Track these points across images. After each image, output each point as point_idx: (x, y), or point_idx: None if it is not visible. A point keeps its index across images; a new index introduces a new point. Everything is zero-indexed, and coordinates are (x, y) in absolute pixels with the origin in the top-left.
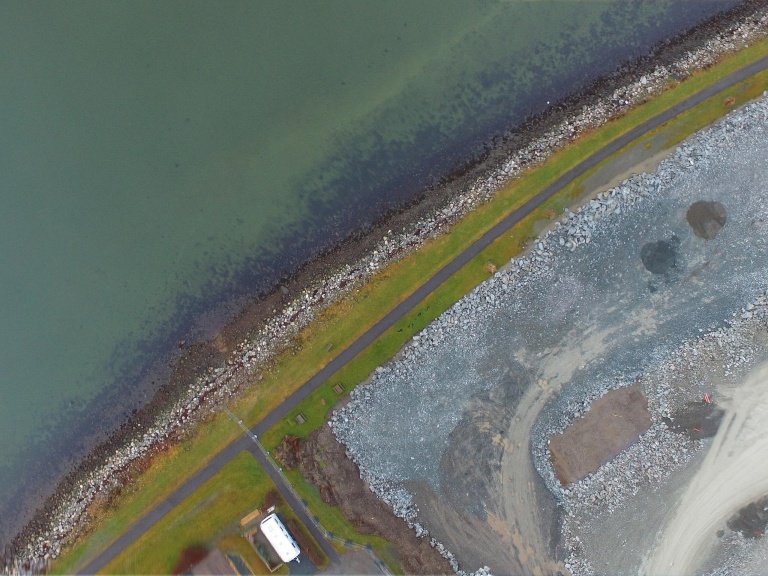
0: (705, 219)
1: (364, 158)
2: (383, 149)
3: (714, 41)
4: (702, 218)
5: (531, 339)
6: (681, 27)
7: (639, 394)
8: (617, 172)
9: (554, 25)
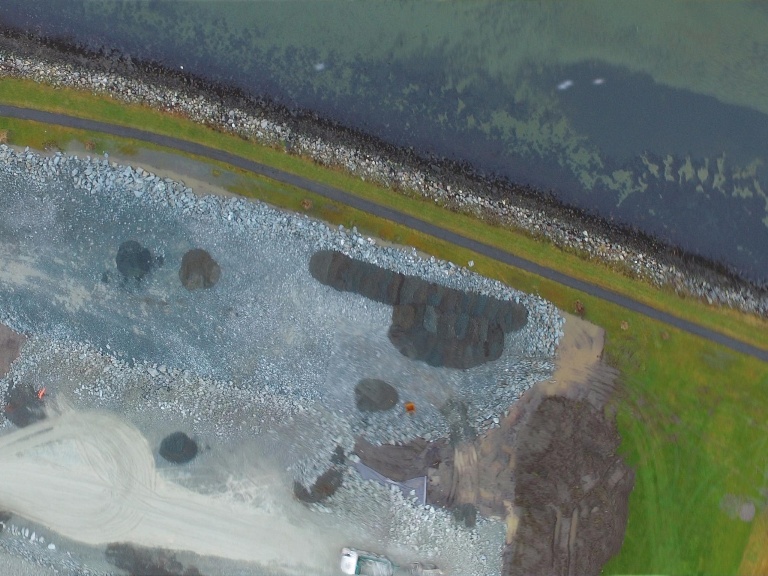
0: (196, 269)
1: None
2: None
3: (347, 151)
4: (193, 264)
5: None
6: (337, 117)
7: (17, 346)
8: (172, 167)
9: (246, 17)
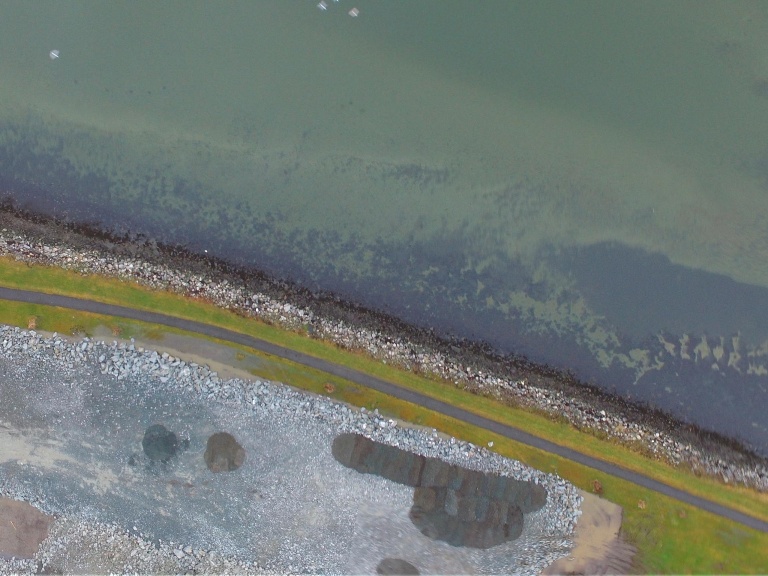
0: (221, 452)
1: (34, 150)
2: (55, 158)
3: (369, 333)
4: (218, 449)
5: (5, 404)
6: (358, 299)
7: (46, 526)
8: (197, 352)
9: (269, 201)
